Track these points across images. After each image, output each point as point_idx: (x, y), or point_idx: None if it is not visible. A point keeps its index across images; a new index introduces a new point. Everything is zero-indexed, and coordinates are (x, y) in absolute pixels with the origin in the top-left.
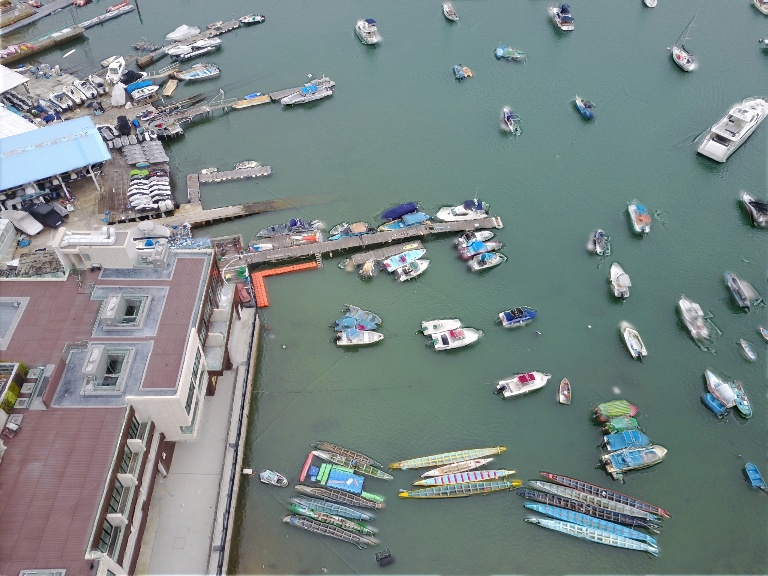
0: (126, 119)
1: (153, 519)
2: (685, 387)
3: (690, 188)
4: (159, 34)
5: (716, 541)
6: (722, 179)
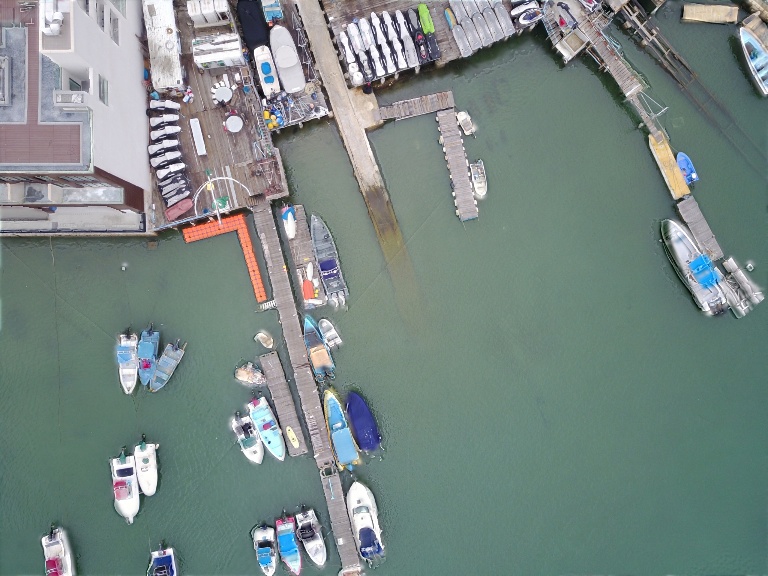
0: None
1: None
2: None
3: None
4: None
5: None
6: None
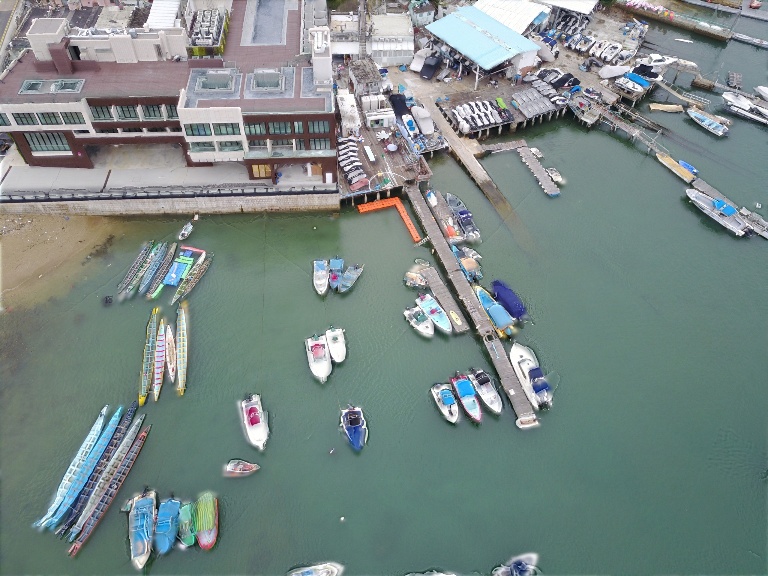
0: (569, 78)
1: (157, 166)
2: None
3: None
4: (760, 81)
5: None
6: None
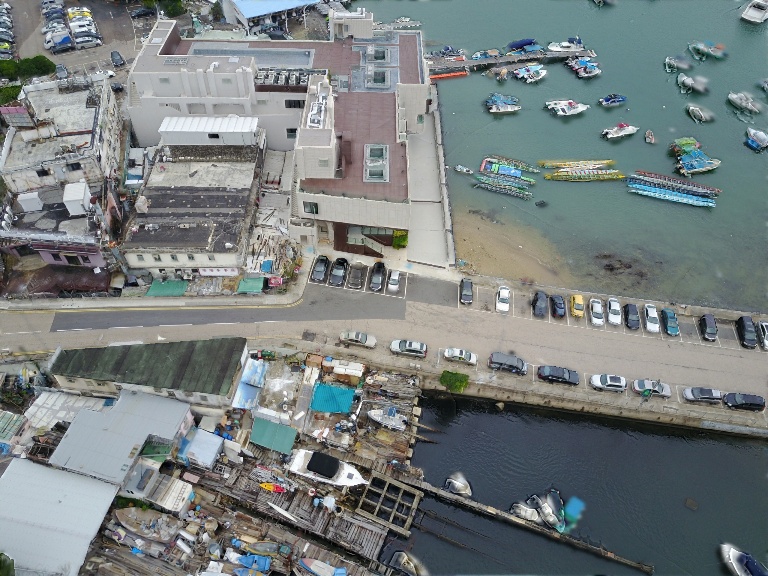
0: None
1: None
2: (732, 141)
3: (735, 41)
4: None
5: (754, 207)
6: (761, 35)
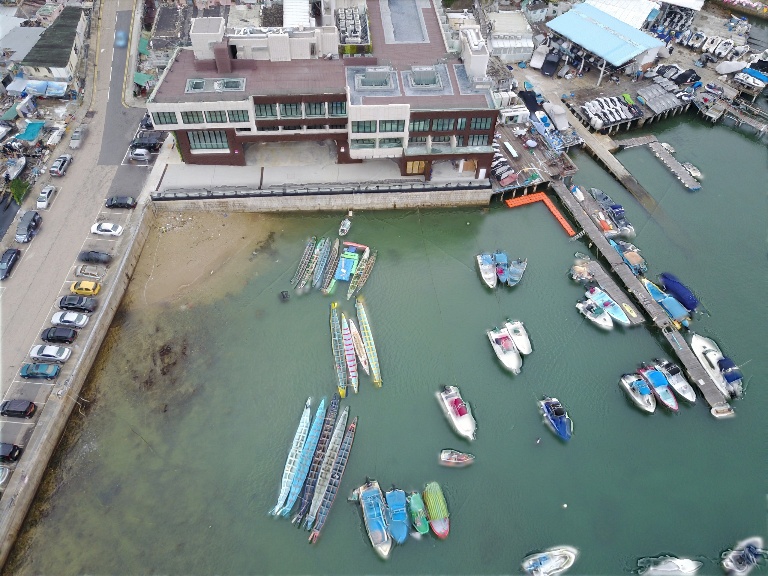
0: (692, 74)
1: (307, 163)
2: None
3: None
4: None
5: None
6: None
